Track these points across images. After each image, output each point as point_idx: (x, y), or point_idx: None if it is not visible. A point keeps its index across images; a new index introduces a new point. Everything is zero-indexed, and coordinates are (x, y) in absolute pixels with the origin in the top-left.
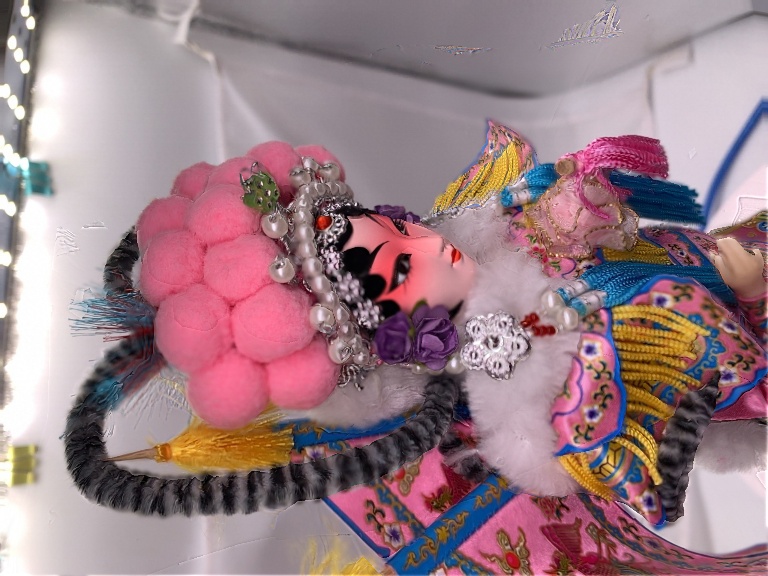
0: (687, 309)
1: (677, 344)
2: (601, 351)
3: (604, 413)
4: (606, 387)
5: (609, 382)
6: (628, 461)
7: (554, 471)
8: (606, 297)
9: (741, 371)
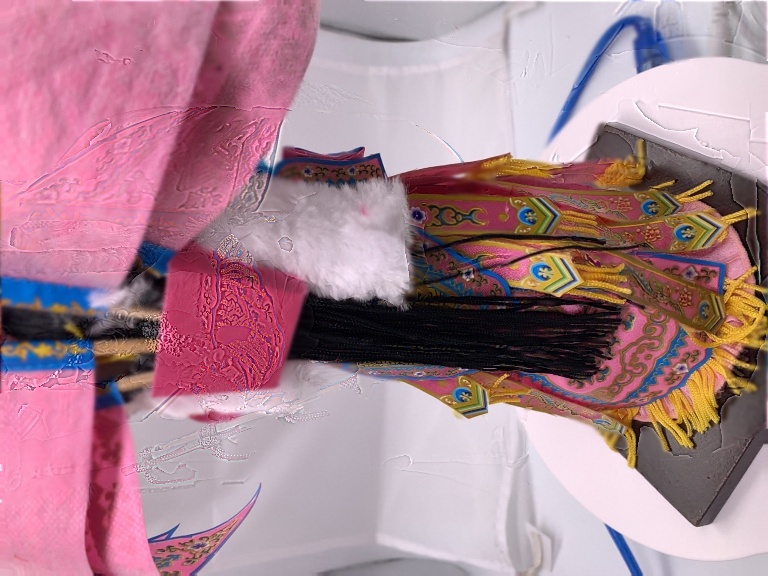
0: None
1: None
2: None
3: None
4: None
5: None
6: None
7: None
8: None
9: None
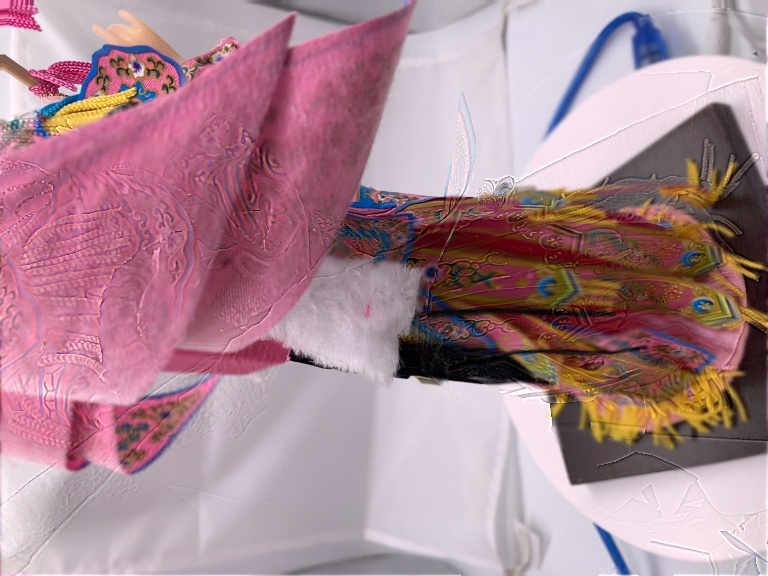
0: (93, 202)
1: (102, 239)
2: (3, 278)
3: (18, 335)
4: (12, 307)
5: (14, 301)
6: (70, 375)
7: (2, 444)
8: (7, 233)
9: (171, 225)
